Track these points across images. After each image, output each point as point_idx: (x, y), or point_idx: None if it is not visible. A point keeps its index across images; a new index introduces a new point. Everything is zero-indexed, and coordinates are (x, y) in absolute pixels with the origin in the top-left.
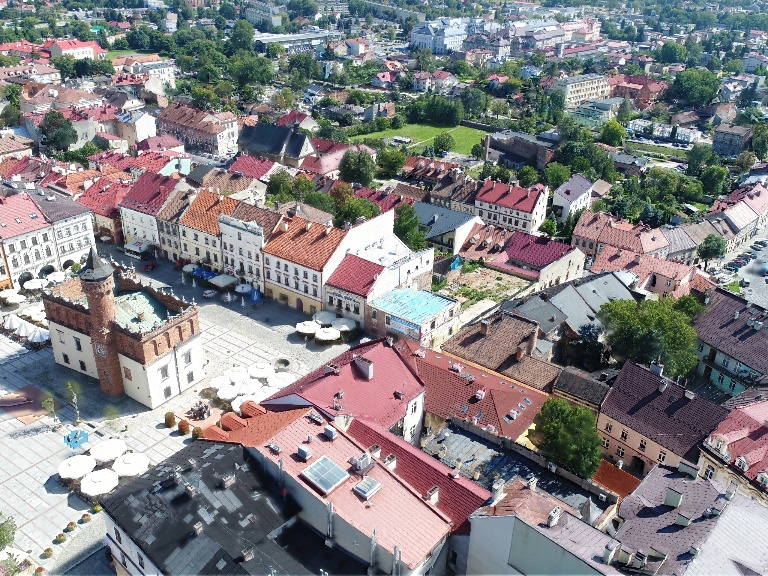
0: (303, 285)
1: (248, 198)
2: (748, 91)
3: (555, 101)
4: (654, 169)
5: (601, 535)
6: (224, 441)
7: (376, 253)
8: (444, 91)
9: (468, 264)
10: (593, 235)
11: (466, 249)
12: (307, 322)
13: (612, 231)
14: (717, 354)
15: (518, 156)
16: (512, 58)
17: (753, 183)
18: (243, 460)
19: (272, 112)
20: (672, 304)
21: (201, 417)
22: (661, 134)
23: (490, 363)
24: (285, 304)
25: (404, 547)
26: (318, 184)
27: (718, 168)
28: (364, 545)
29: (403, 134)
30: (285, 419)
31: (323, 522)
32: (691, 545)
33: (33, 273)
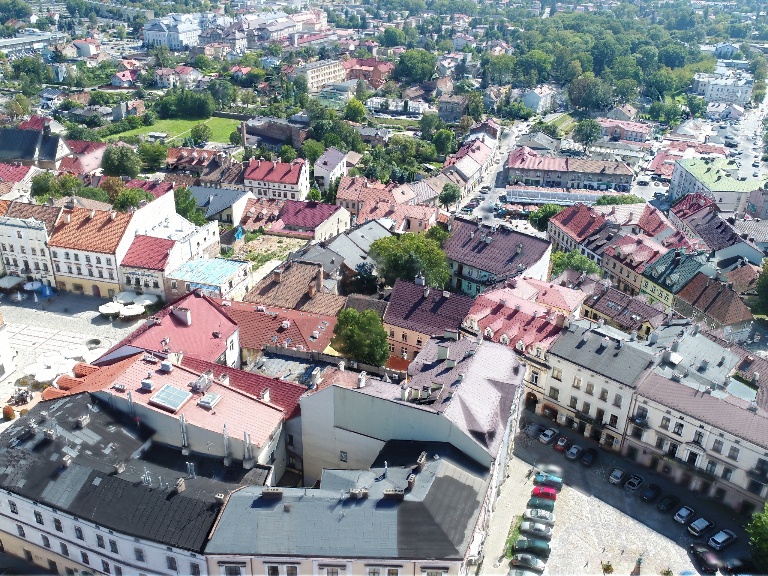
0: (97, 271)
1: (20, 197)
2: (460, 66)
3: (299, 86)
4: (394, 137)
5: (397, 386)
6: (68, 395)
7: (163, 232)
8: (190, 86)
9: (250, 234)
10: (354, 196)
11: (245, 223)
12: (109, 303)
13: (369, 191)
14: (463, 267)
15: (274, 139)
16: (250, 50)
17: (473, 140)
18: (92, 404)
19: (8, 120)
20: (424, 235)
21: (23, 402)
22: (396, 108)
23: (288, 304)
24: (80, 293)
25: (251, 434)
26: (84, 182)
27: (445, 131)
28: (217, 442)
29: (157, 130)
30: (122, 366)
31: (177, 436)
32: (458, 375)
33: None
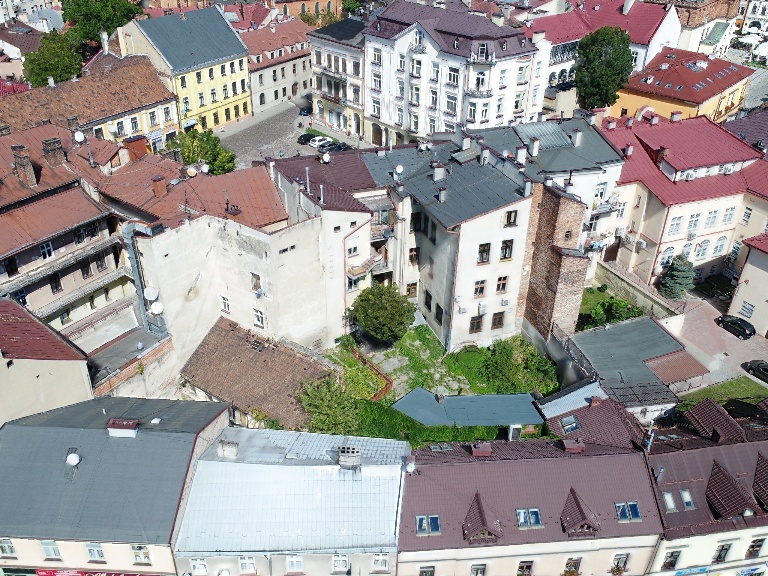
0: None
1: None
2: None
3: None
4: None
5: None
6: None
7: None
8: None
9: None
10: None
11: None
12: None
13: None
14: None
15: None
16: None
17: None
18: None
19: None
20: None
21: None
22: None
23: (763, 106)
24: None
25: None
26: None
27: None
28: None
29: None
30: None
31: None
32: None
33: (762, 25)
